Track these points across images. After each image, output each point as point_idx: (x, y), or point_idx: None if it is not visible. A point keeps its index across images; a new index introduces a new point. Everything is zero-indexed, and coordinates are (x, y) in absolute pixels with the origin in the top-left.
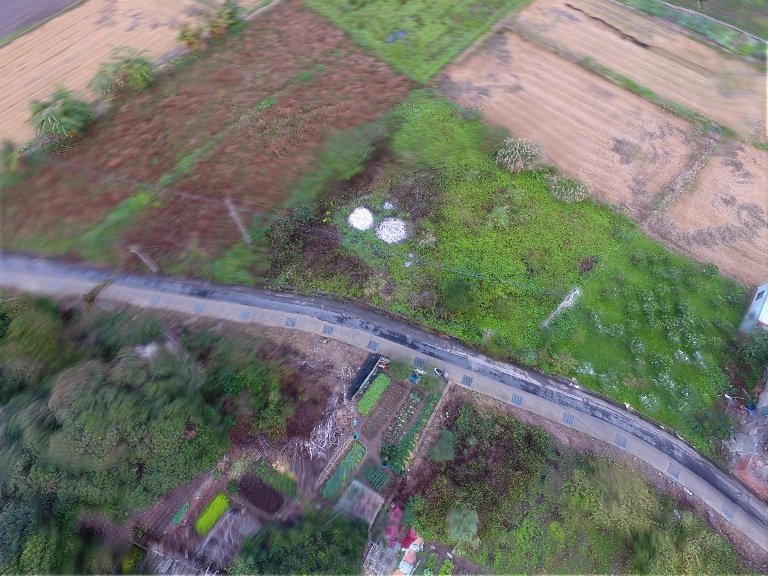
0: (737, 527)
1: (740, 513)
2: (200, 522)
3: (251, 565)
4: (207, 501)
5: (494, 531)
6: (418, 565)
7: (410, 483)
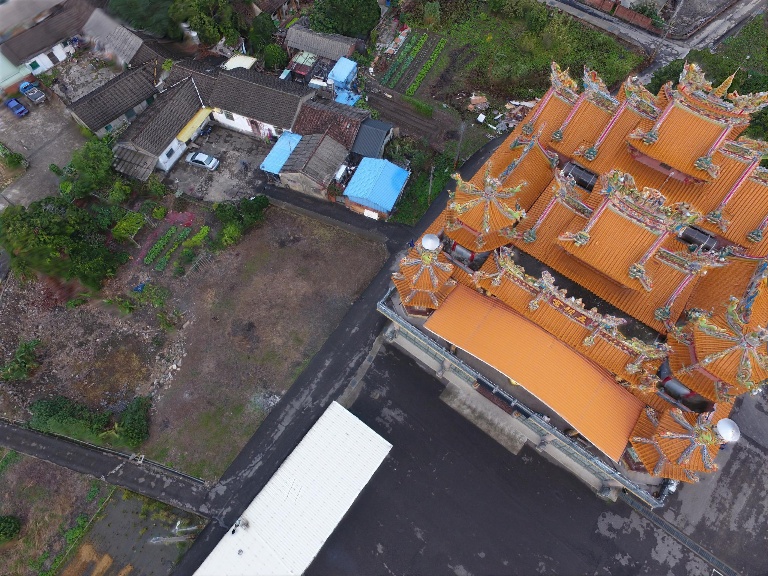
0: (585, 20)
1: (588, 16)
2: (287, 25)
3: (321, 1)
4: (289, 21)
5: (450, 23)
6: (408, 36)
7: (403, 11)
